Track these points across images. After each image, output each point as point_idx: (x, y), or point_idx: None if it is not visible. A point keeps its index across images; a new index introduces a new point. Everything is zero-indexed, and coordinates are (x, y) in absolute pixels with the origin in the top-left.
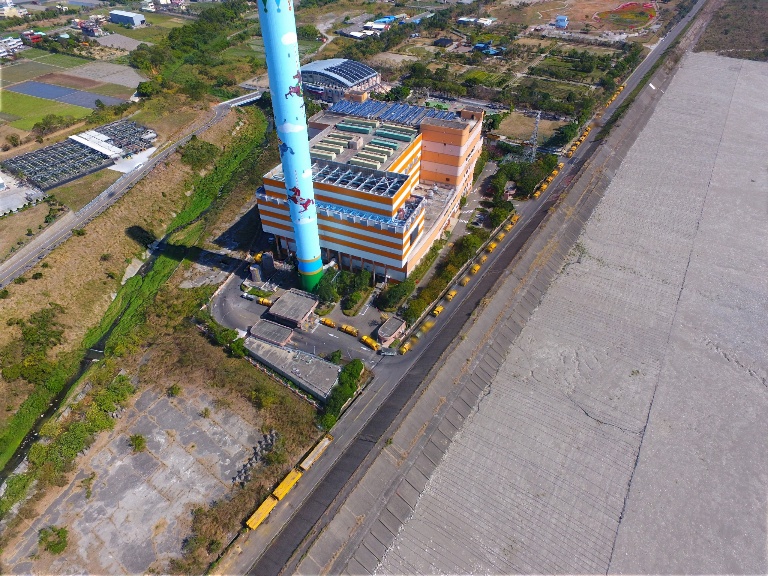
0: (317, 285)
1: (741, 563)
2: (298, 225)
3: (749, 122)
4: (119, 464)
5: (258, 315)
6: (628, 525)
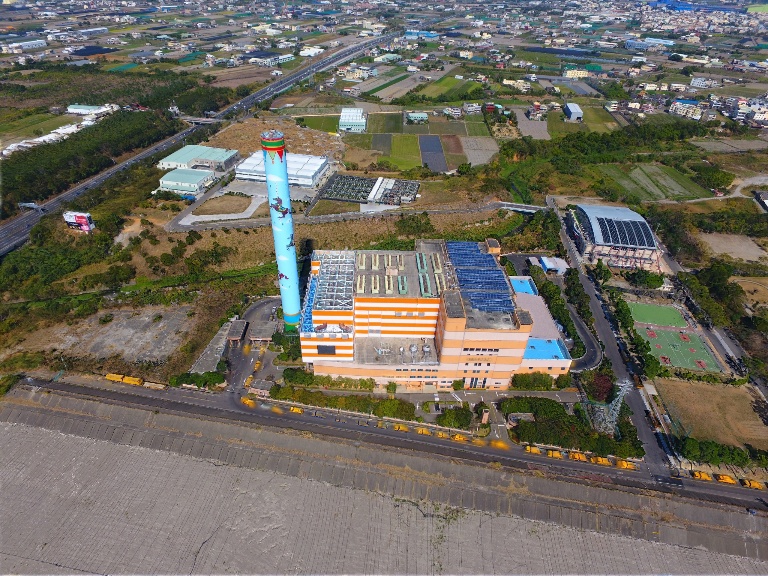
0: None
1: None
2: None
3: None
4: (146, 319)
5: None
6: None
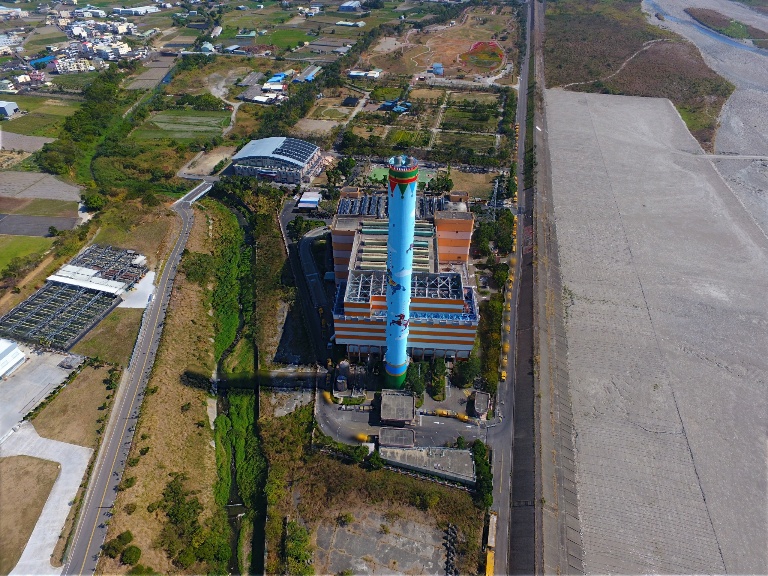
0: (404, 381)
1: None
2: (398, 341)
3: (616, 152)
4: None
5: (366, 423)
6: (711, 503)
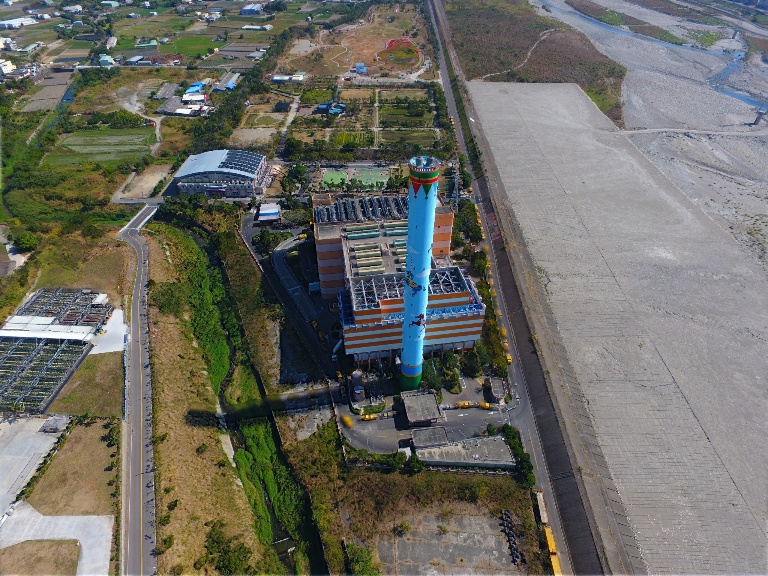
0: (420, 380)
1: (764, 429)
2: (417, 341)
3: (546, 136)
4: None
5: (393, 429)
6: (714, 440)
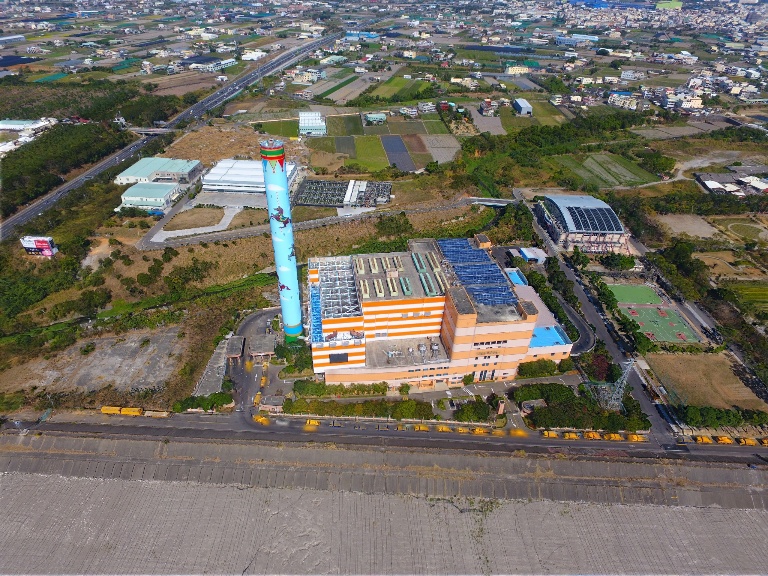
0: None
1: None
2: None
3: None
4: (132, 344)
5: None
6: None
